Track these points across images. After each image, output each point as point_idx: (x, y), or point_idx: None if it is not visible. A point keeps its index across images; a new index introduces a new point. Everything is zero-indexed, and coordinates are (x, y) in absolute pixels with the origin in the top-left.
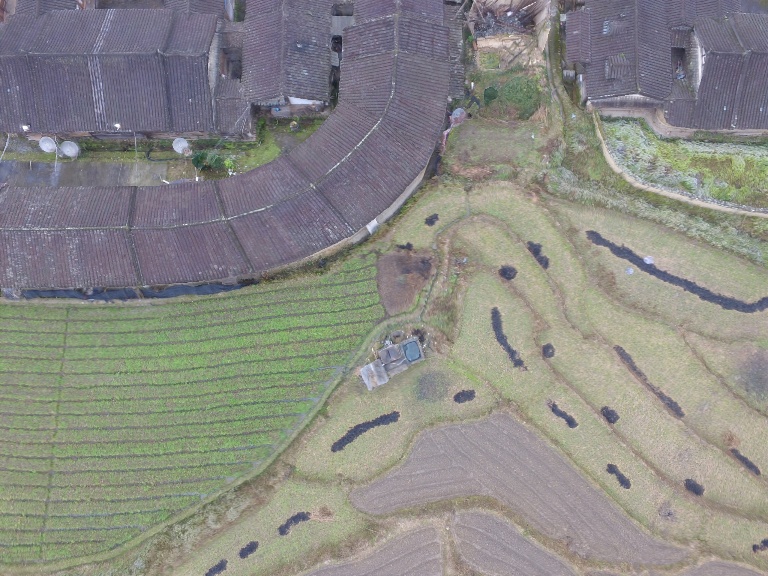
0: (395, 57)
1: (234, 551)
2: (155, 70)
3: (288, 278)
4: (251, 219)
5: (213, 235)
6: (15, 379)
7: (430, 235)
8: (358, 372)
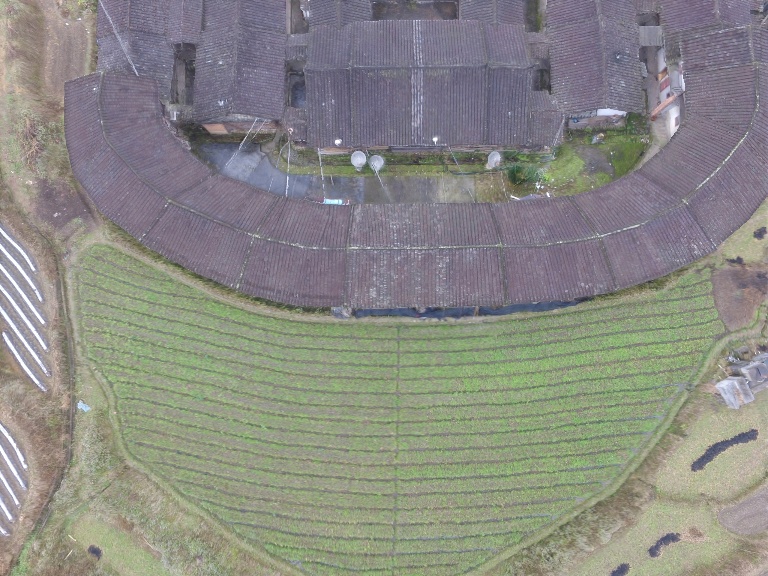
0: (757, 69)
1: (605, 574)
2: (480, 83)
3: (624, 294)
4: (623, 236)
5: (585, 253)
6: (350, 400)
7: (760, 249)
8: (713, 390)
